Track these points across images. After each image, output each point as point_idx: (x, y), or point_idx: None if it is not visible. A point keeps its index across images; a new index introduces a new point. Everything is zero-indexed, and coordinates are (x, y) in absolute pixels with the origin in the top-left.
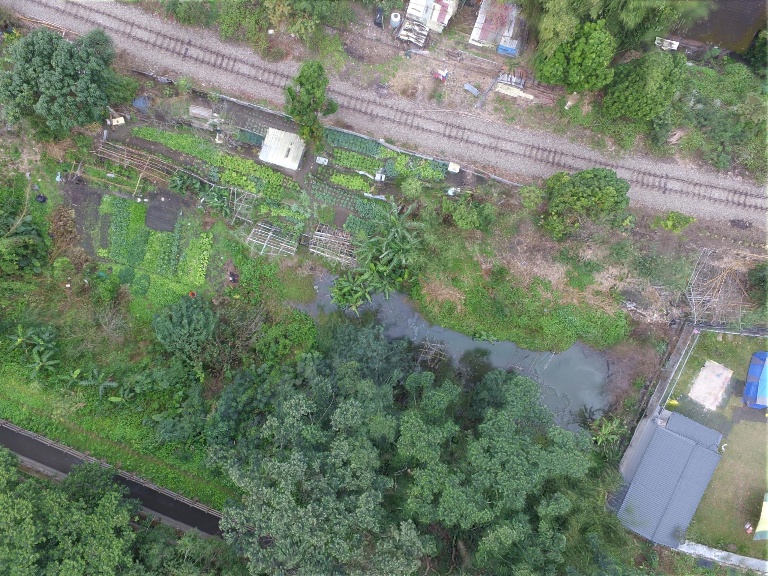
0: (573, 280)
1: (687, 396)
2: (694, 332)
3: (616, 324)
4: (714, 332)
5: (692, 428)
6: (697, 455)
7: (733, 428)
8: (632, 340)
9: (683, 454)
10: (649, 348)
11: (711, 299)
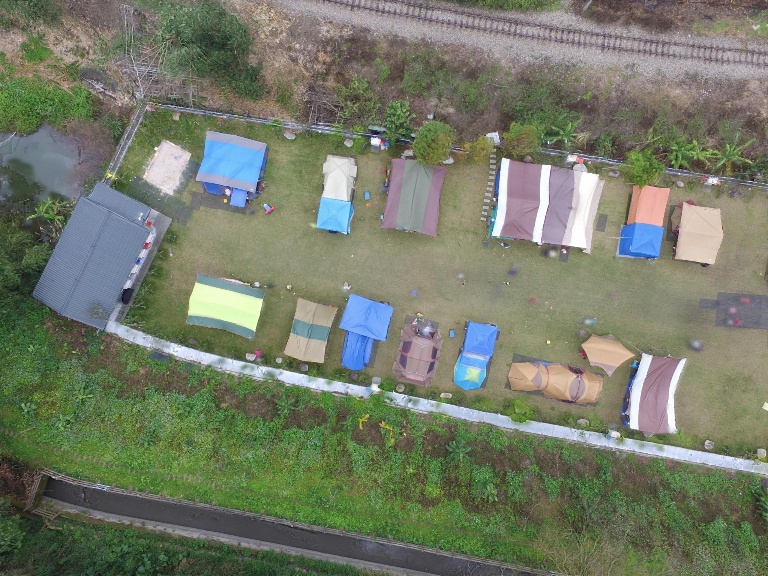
0: (27, 53)
1: (142, 178)
2: (146, 109)
3: (75, 102)
4: (168, 110)
5: (117, 200)
6: (112, 225)
7: (192, 215)
8: (92, 120)
9: (97, 223)
10: (95, 123)
11: (156, 71)
